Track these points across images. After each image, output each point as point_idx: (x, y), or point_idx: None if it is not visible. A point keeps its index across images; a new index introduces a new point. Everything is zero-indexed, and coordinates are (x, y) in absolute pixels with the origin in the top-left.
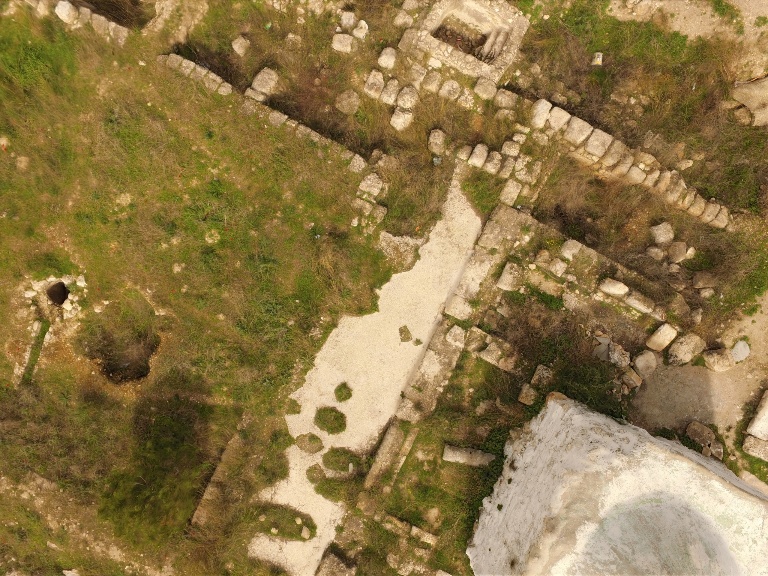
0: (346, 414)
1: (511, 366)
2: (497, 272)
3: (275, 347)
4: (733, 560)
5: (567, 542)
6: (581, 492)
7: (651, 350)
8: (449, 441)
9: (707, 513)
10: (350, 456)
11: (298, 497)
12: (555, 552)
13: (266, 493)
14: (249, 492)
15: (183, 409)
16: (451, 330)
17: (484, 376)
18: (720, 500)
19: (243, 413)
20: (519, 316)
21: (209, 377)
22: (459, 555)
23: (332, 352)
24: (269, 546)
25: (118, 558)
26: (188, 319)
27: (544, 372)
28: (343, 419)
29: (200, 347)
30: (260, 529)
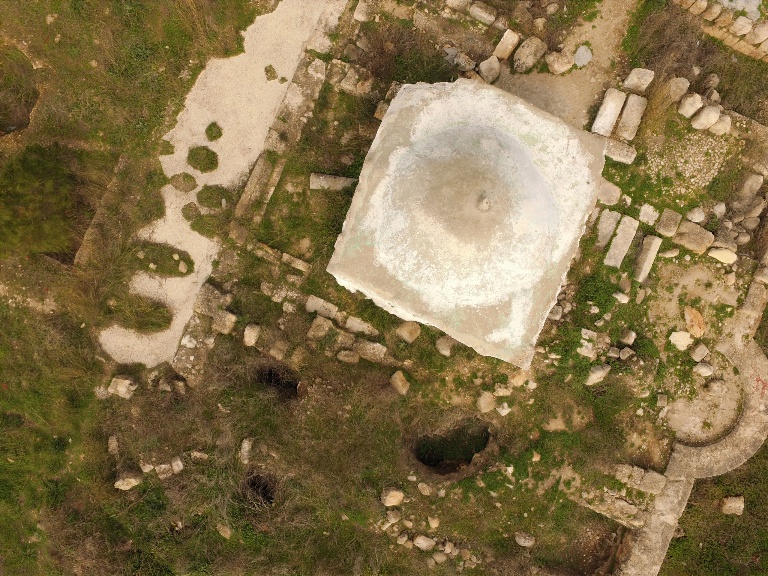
0: (218, 153)
1: (368, 89)
2: (354, 5)
3: (147, 91)
4: (535, 168)
5: (381, 167)
6: (396, 125)
7: (498, 60)
8: (315, 169)
9: (513, 133)
10: (222, 192)
11: (175, 235)
12: (372, 180)
13: (144, 232)
14: (127, 230)
15: (62, 155)
16: (312, 63)
17: (348, 109)
18: (525, 121)
19: (119, 157)
20: (374, 41)
21: (84, 121)
22: (331, 283)
23: (201, 93)
24: (149, 283)
25: (1, 292)
26: (63, 69)
27: (397, 87)
28: (214, 157)
29: (75, 93)
30: (140, 266)
